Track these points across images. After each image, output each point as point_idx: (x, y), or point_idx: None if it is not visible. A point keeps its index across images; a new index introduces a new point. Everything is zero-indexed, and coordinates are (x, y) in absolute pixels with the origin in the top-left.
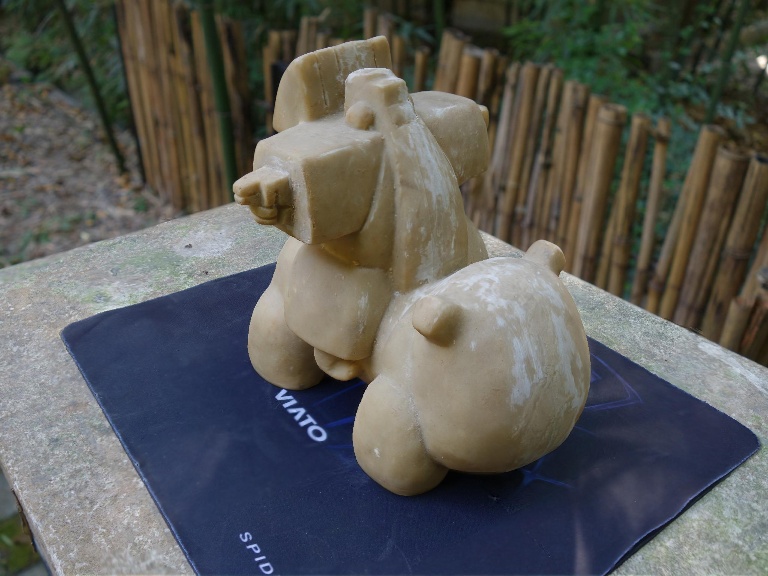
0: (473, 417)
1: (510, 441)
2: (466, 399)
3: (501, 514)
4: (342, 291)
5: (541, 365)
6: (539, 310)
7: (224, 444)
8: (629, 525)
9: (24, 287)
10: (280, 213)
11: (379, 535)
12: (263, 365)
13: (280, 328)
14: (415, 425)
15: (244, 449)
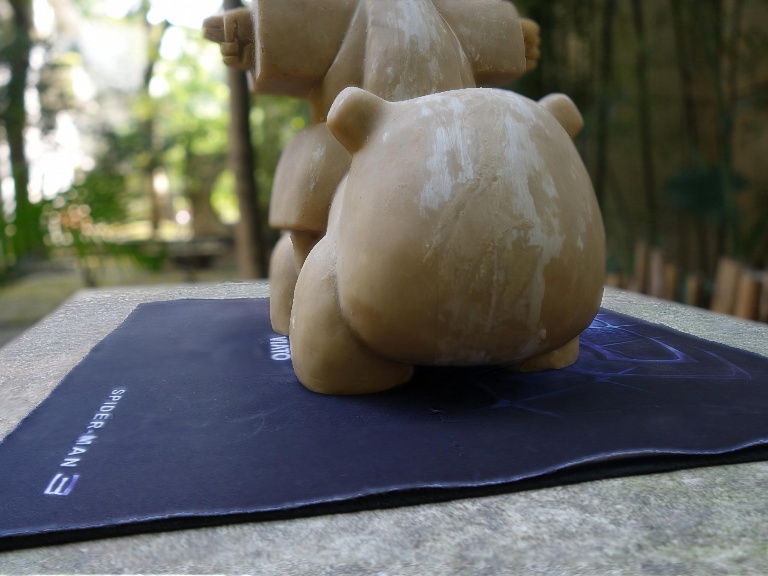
0: (375, 229)
1: (422, 268)
2: (369, 205)
3: (430, 420)
4: (301, 146)
5: (473, 162)
6: (487, 108)
7: (182, 350)
8: (624, 451)
9: (151, 293)
10: (242, 51)
11: (254, 409)
12: (271, 308)
13: (285, 254)
14: (331, 274)
15: (196, 355)
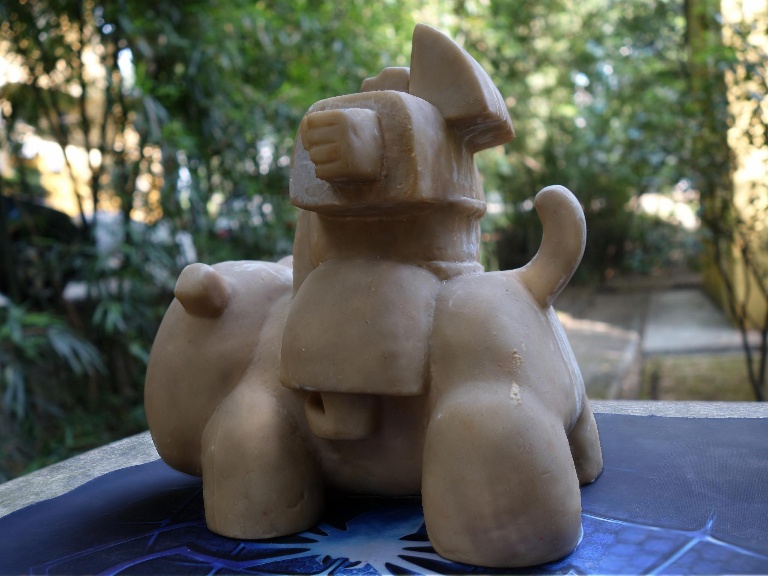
0: None
1: None
2: None
3: None
4: None
5: None
6: None
7: None
8: (111, 485)
9: None
10: None
11: None
12: None
13: None
14: None
15: None
